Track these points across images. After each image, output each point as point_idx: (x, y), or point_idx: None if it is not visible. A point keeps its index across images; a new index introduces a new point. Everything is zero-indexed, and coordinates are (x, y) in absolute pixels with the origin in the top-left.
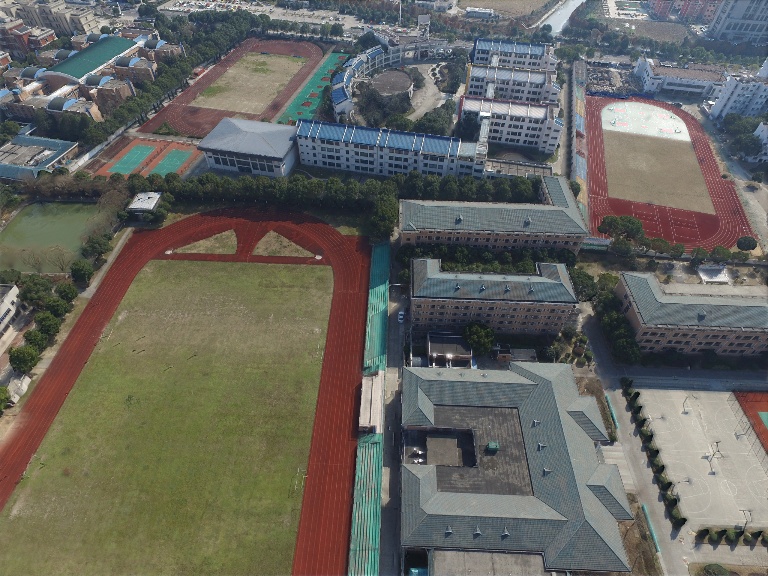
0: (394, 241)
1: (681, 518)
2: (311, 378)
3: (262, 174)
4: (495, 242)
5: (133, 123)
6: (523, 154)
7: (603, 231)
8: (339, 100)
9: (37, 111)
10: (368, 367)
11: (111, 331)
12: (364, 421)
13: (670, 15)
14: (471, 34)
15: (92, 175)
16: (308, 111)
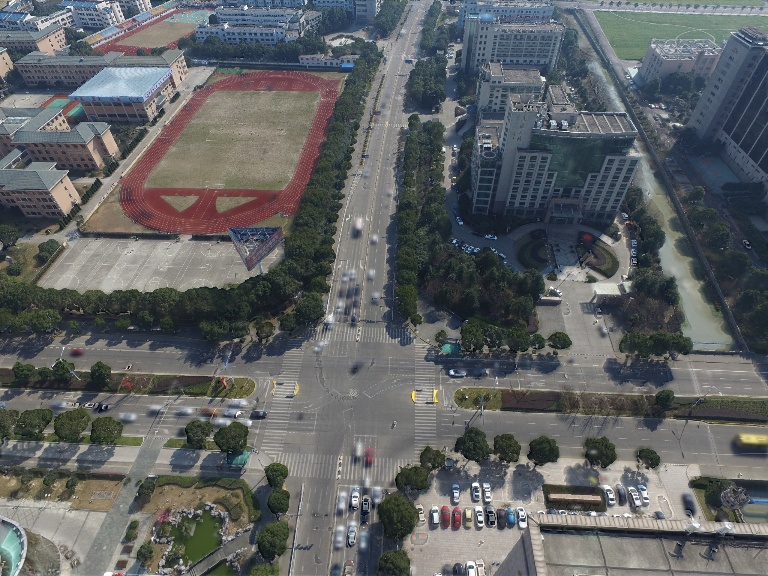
0: None
1: None
2: None
3: None
4: None
5: None
6: None
7: (71, 49)
8: None
9: None
10: None
11: None
12: None
13: None
14: None
15: None
16: None
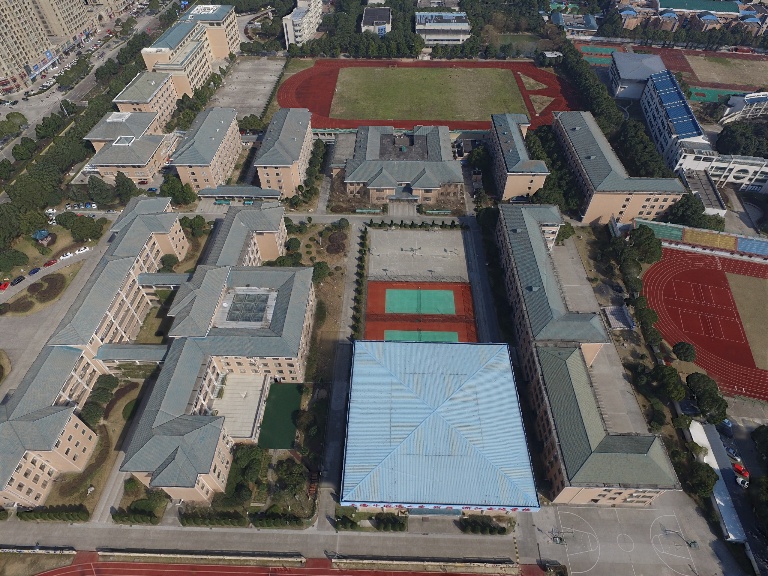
0: None
1: None
2: (444, 118)
3: None
4: None
5: None
6: (764, 215)
7: None
8: None
9: (613, 8)
10: None
11: (460, 69)
12: None
13: None
14: None
15: (574, 43)
16: None
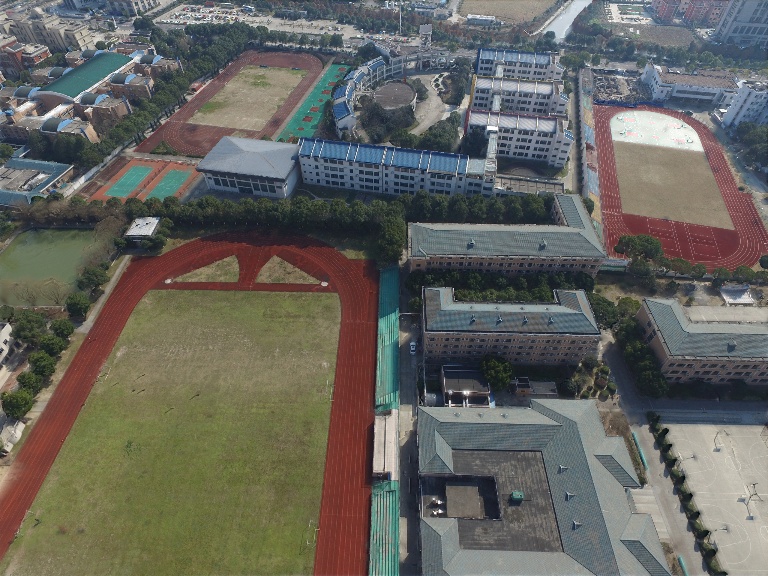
0: (403, 265)
1: (721, 572)
2: (320, 418)
3: (264, 195)
4: (509, 266)
5: (130, 142)
6: (532, 168)
7: (620, 251)
8: (341, 115)
9: (31, 133)
10: (380, 405)
11: (109, 369)
12: (378, 466)
13: (674, 19)
14: (473, 42)
15: (88, 199)
16: (309, 126)
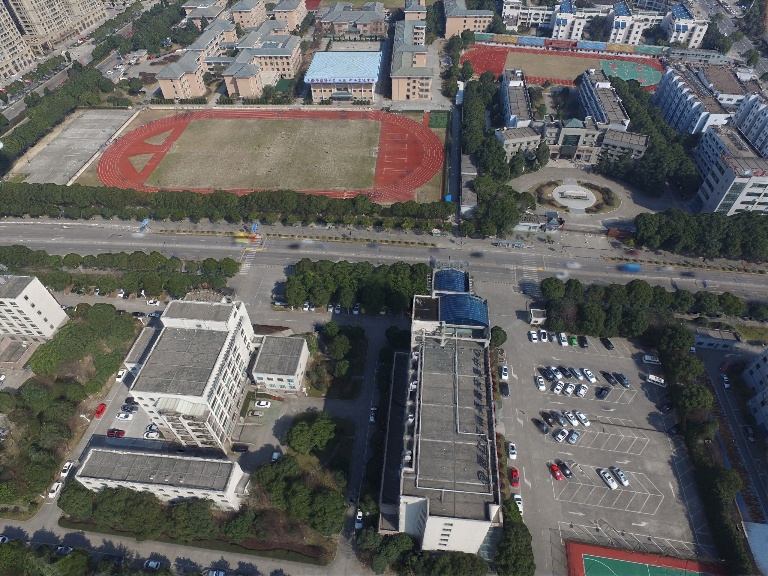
0: None
1: None
2: (386, 6)
3: None
4: None
5: None
6: None
7: None
8: None
9: None
10: None
11: None
12: None
13: None
14: (747, 26)
15: None
16: None
